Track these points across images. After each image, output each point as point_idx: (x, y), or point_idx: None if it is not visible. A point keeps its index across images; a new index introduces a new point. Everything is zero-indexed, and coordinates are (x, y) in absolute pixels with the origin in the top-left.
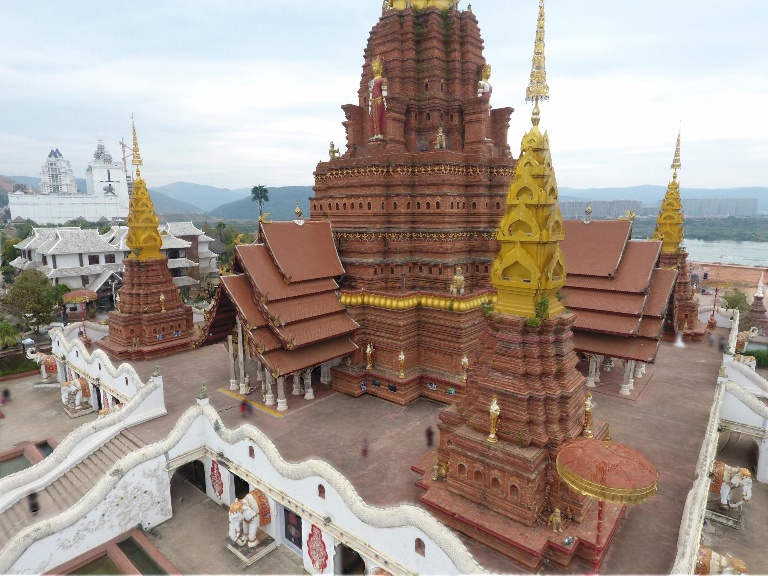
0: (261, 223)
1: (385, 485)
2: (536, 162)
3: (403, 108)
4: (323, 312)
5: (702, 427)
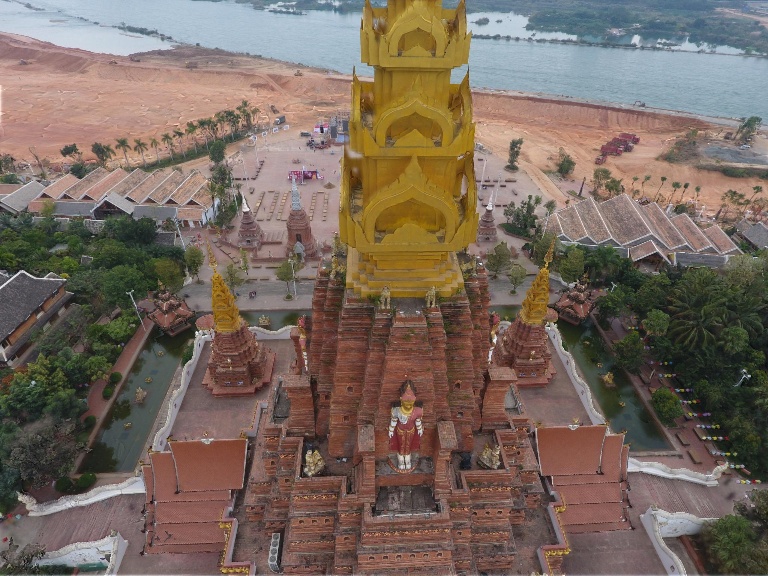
0: None
1: None
2: None
3: None
4: None
5: (651, 548)
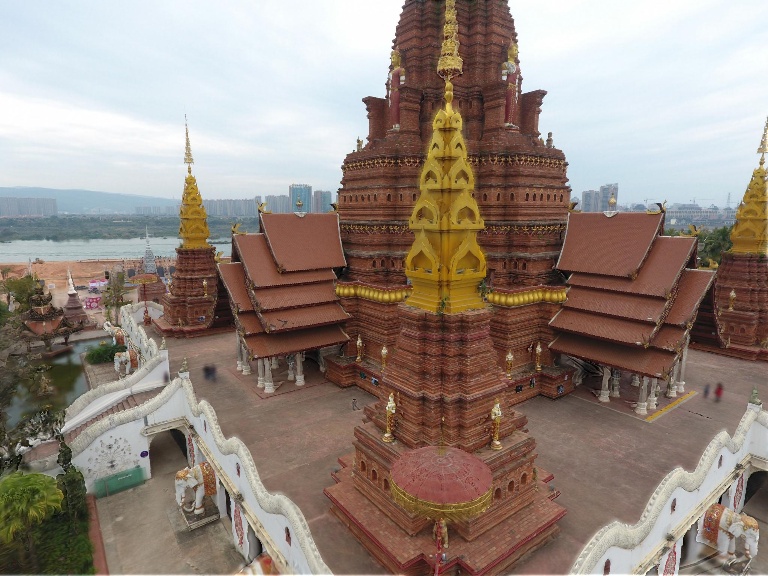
0: None
1: (765, 368)
2: None
3: None
4: None
5: None
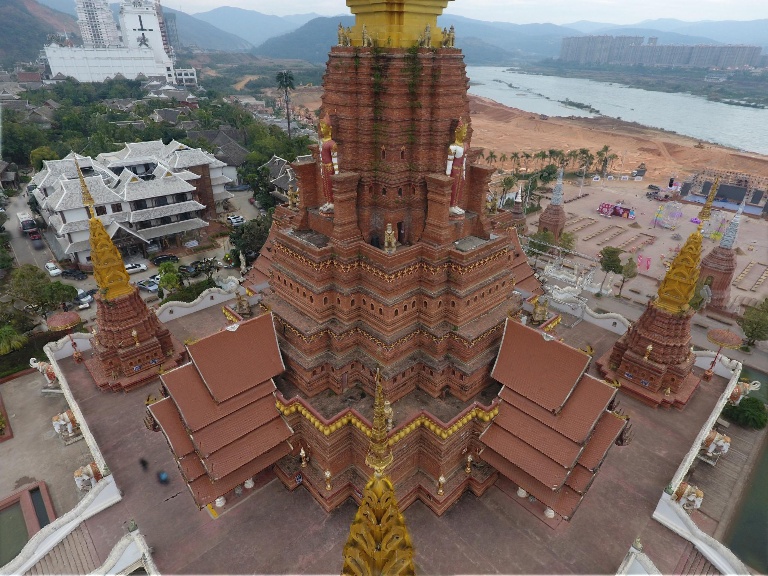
0: (186, 346)
1: None
2: (372, 520)
3: (353, 185)
4: (254, 426)
5: None
